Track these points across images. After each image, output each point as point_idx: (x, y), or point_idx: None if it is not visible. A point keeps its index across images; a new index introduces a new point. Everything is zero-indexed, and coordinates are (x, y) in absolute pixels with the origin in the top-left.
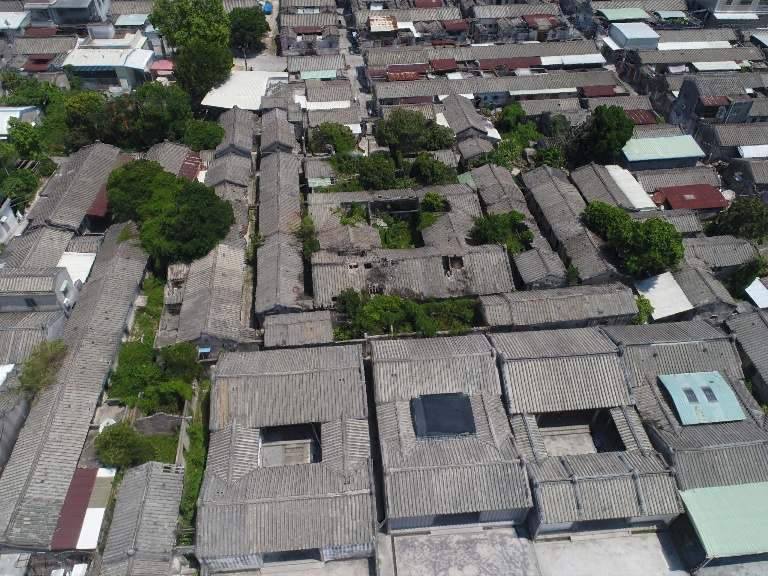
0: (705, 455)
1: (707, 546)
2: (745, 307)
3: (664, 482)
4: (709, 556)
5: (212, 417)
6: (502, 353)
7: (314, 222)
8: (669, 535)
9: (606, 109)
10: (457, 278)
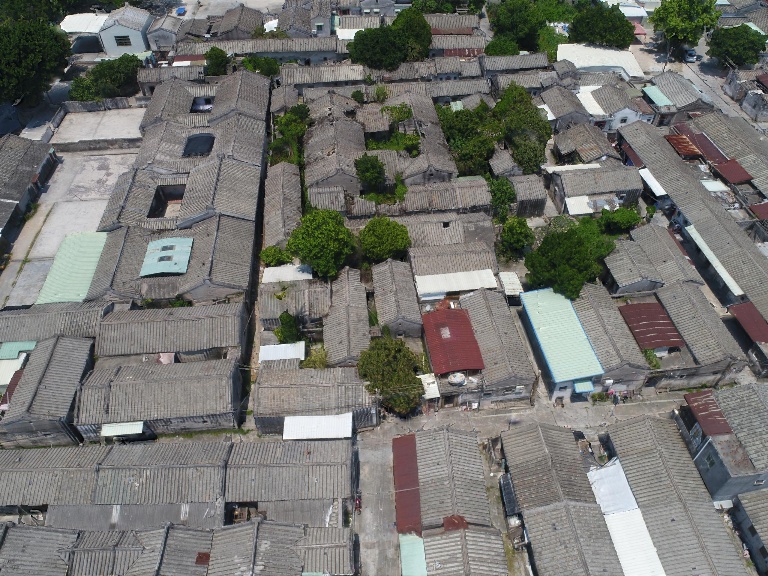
0: None
1: (71, 234)
2: (268, 339)
3: None
4: (66, 234)
5: (223, 78)
6: (222, 153)
7: (391, 99)
8: None
9: (568, 235)
10: None
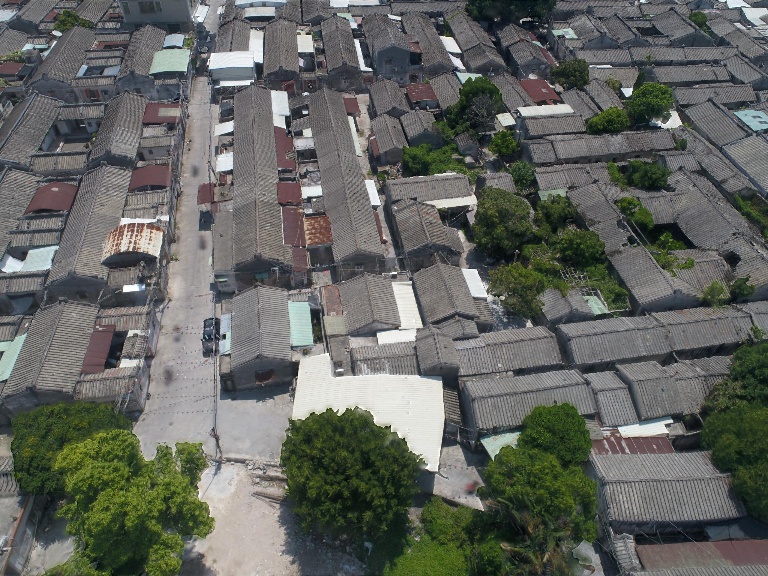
0: None
1: None
2: None
3: None
4: None
5: None
6: None
7: (694, 292)
8: None
9: (480, 83)
10: (718, 201)
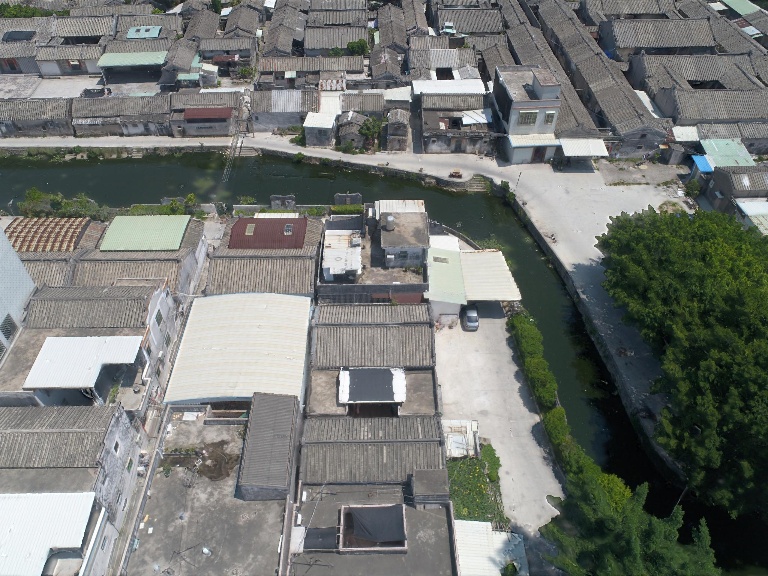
0: (123, 43)
1: (98, 63)
2: None
3: (97, 49)
4: (97, 66)
5: None
6: None
7: None
8: (106, 78)
9: None
10: (70, 4)
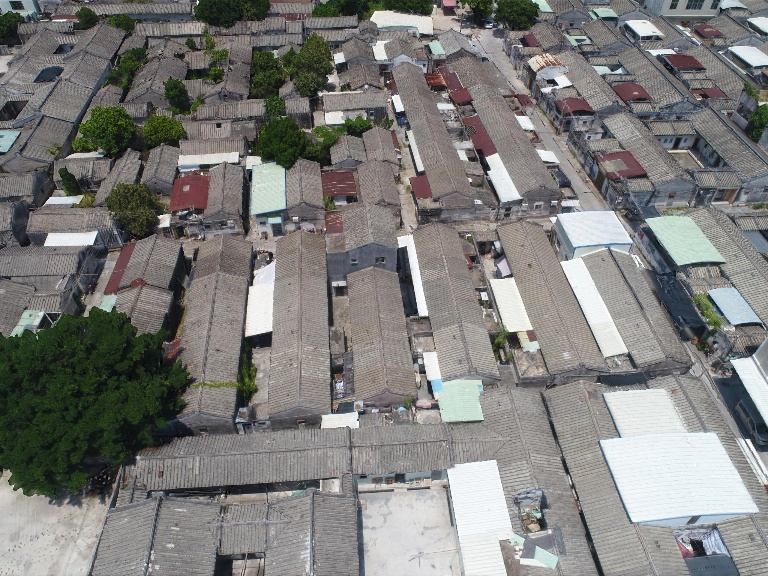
0: None
1: None
2: (58, 194)
3: None
4: None
5: (87, 30)
6: None
7: None
8: None
9: (284, 121)
10: None
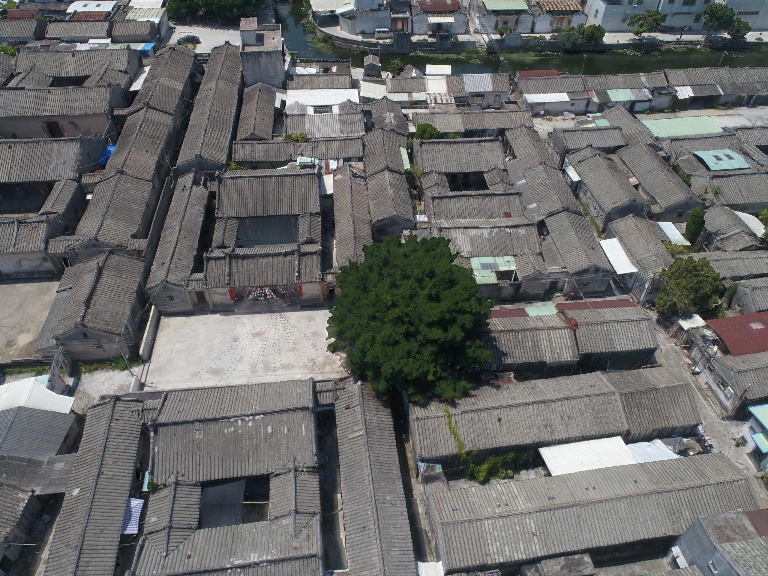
0: None
1: None
2: (681, 227)
3: None
4: None
5: None
6: None
7: None
8: None
9: None
10: None
